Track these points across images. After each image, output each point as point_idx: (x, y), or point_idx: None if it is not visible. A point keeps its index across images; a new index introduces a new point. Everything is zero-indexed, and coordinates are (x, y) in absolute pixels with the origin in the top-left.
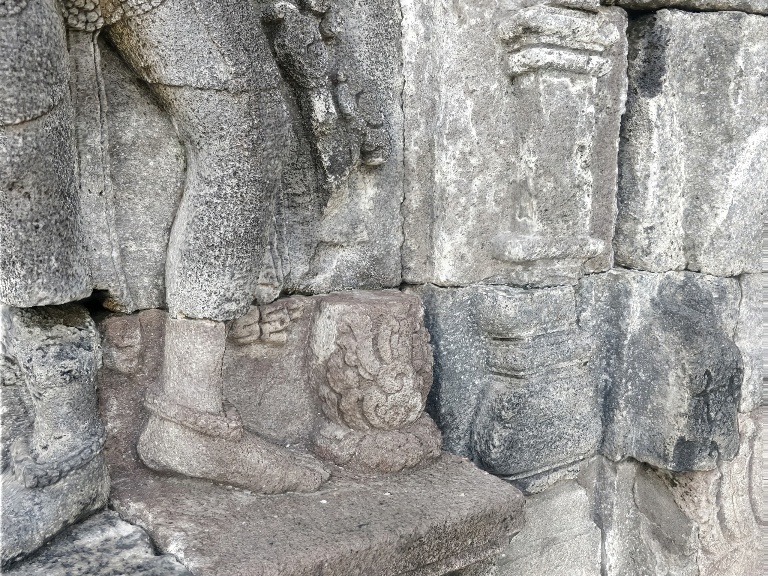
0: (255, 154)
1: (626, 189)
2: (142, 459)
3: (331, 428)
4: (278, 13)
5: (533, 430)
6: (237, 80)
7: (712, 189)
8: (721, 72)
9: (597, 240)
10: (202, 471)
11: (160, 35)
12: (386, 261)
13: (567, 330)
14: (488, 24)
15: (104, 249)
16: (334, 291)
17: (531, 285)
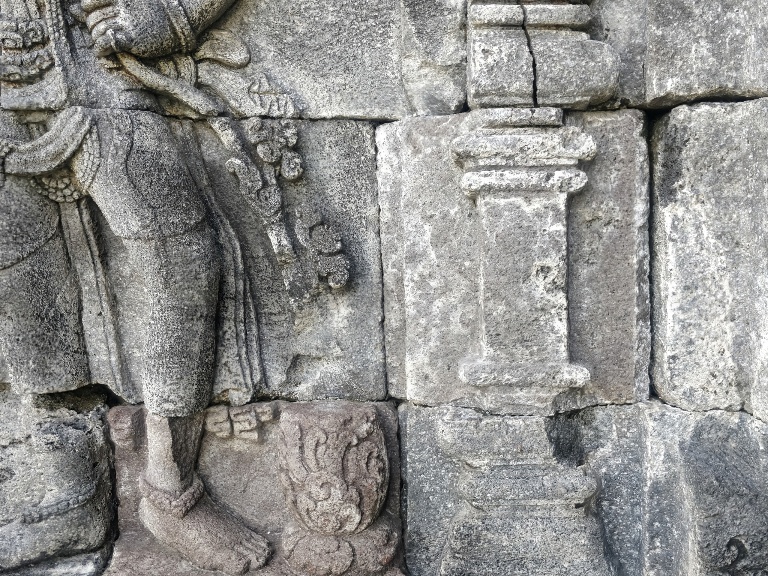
0: (169, 286)
1: (657, 310)
2: (140, 519)
3: (290, 523)
4: (228, 168)
5: (493, 567)
6: (144, 231)
7: (757, 313)
8: (760, 171)
9: (577, 368)
10: (161, 537)
11: (99, 202)
12: (364, 376)
13: (543, 464)
14: (445, 151)
15: (102, 355)
16: (317, 400)
17: (490, 411)
